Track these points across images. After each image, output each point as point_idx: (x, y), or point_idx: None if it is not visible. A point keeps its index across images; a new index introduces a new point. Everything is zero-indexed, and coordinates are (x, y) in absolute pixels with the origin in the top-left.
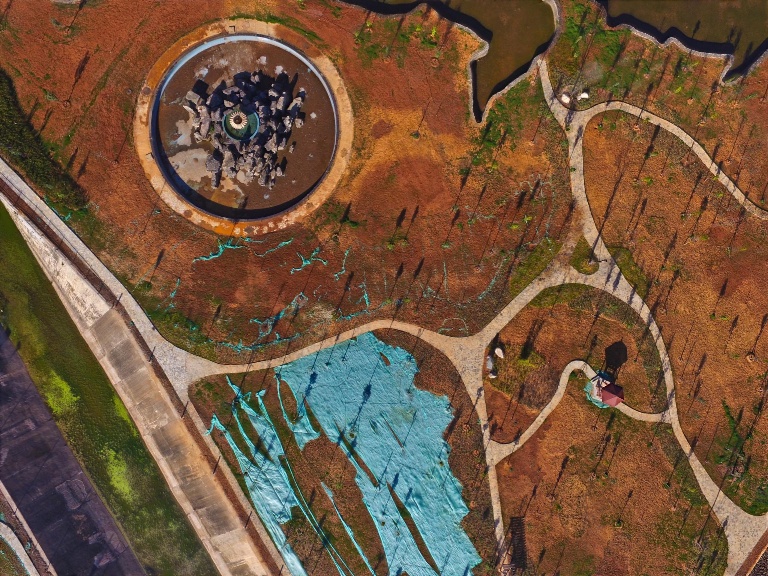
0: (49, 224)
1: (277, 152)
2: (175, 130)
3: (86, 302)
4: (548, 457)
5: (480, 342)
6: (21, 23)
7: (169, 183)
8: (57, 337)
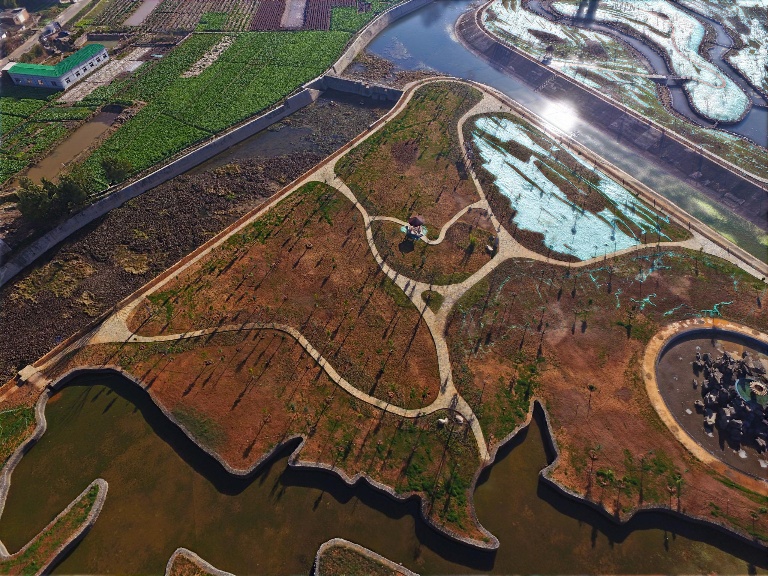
0: None
1: None
2: None
3: None
4: (448, 202)
5: (504, 254)
6: None
7: None
8: None
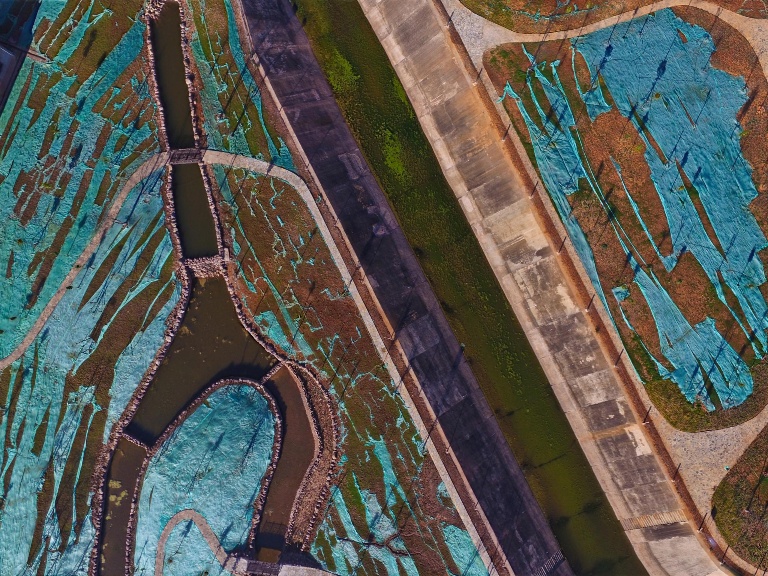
0: None
1: None
2: None
3: None
4: None
5: None
6: None
7: None
8: (341, 16)
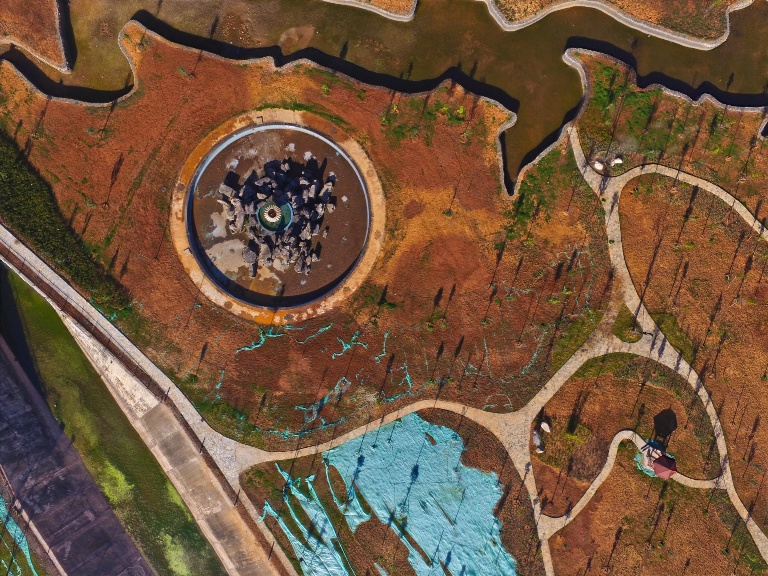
0: (96, 325)
1: (311, 238)
2: (210, 223)
3: (135, 396)
4: (601, 529)
5: (525, 417)
6: (57, 130)
7: (208, 276)
8: (109, 428)
